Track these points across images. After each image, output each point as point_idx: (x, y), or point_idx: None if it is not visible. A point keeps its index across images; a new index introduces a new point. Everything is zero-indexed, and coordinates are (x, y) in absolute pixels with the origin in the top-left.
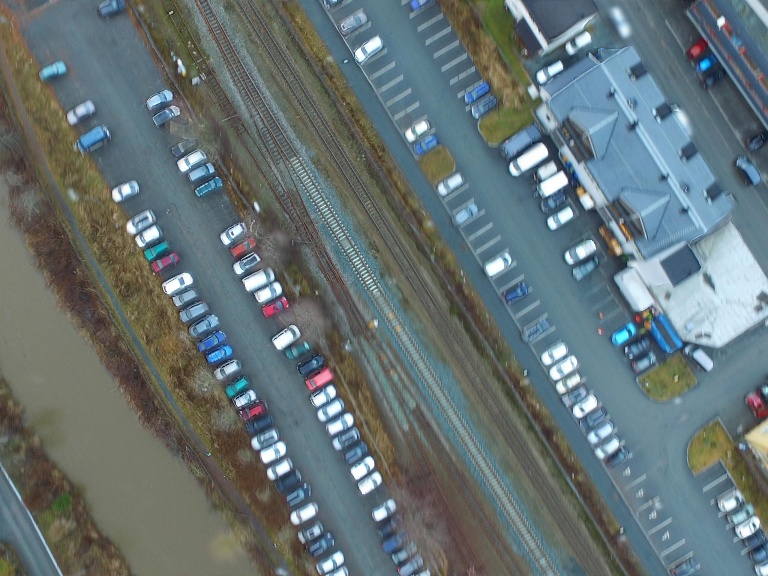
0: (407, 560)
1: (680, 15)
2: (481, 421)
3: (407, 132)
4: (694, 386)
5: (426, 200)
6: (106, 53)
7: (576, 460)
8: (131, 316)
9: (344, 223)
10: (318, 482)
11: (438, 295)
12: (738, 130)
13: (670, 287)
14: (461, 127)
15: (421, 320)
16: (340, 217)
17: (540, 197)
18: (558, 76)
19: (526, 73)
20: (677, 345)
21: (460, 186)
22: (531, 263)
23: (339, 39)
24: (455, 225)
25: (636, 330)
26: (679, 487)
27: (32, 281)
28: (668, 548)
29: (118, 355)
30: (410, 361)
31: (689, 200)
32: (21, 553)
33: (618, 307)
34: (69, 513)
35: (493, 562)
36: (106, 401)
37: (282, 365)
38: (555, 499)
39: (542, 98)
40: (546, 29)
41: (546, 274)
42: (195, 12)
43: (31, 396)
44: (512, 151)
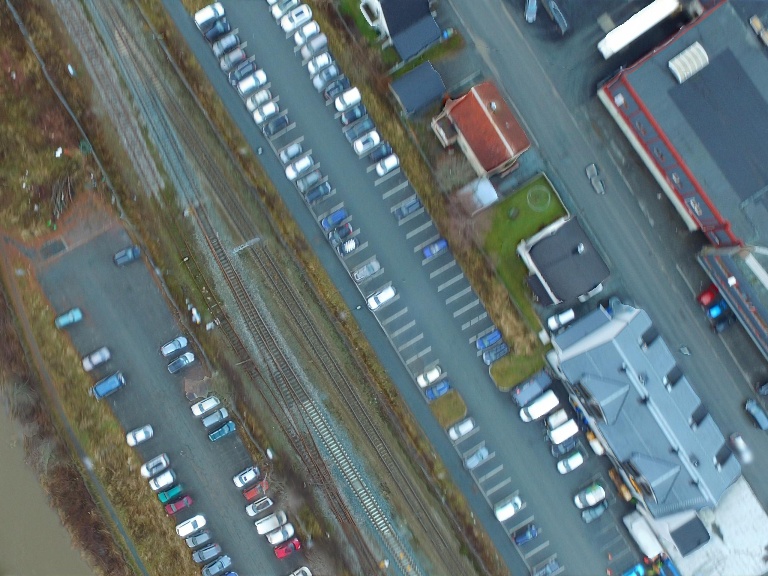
0: None
1: (691, 259)
2: None
3: (419, 378)
4: None
5: (437, 443)
6: (121, 299)
7: None
8: (145, 557)
9: (356, 465)
10: None
11: (448, 536)
12: (748, 373)
13: None
14: (472, 372)
15: (431, 560)
16: (352, 459)
17: (550, 441)
18: (569, 327)
19: (537, 318)
20: None
21: (471, 430)
22: (541, 505)
23: (352, 285)
24: (466, 469)
25: (644, 571)
26: None
27: (47, 519)
28: None
29: None
30: None
31: (699, 473)
32: None
33: (627, 547)
34: None
35: None
36: None
37: None
38: None
39: (553, 345)
40: (558, 293)
41: (556, 516)
42: (210, 258)
43: None
44: (523, 402)
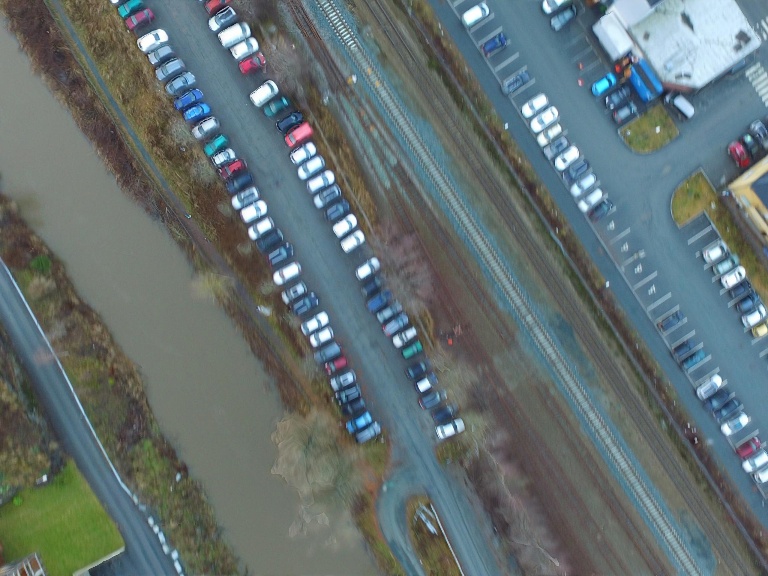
0: (392, 317)
1: None
2: (463, 177)
3: None
4: (676, 137)
5: None
6: None
7: (560, 214)
8: (106, 75)
9: None
10: (300, 243)
11: (416, 49)
12: None
13: (648, 27)
14: None
15: (400, 75)
16: None
17: None
18: None
19: None
20: (657, 90)
21: None
22: (509, 15)
23: None
24: None
25: (616, 80)
26: (664, 240)
27: (5, 45)
28: (654, 302)
29: (94, 117)
30: (390, 117)
31: None
32: (0, 311)
33: (598, 59)
34: (48, 276)
35: (479, 320)
36: (83, 165)
37: (261, 124)
38: (540, 254)
39: None
40: None
41: (524, 25)
42: None
43: (7, 162)
44: None
